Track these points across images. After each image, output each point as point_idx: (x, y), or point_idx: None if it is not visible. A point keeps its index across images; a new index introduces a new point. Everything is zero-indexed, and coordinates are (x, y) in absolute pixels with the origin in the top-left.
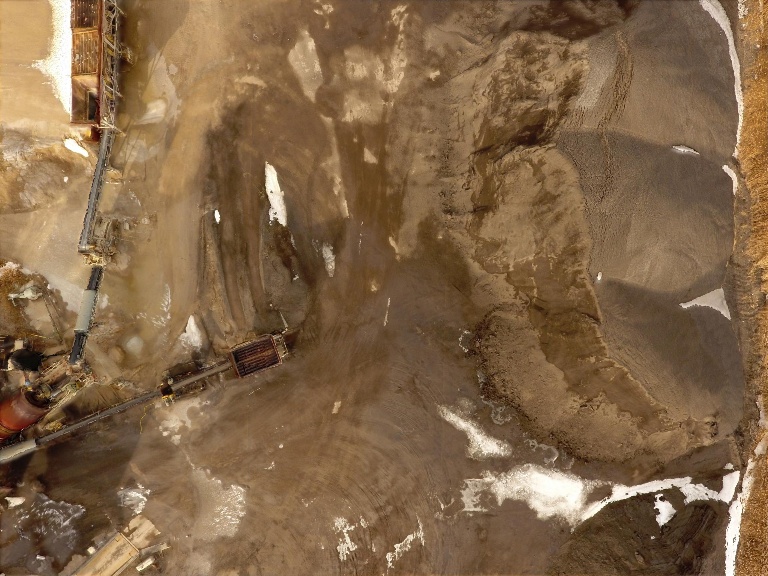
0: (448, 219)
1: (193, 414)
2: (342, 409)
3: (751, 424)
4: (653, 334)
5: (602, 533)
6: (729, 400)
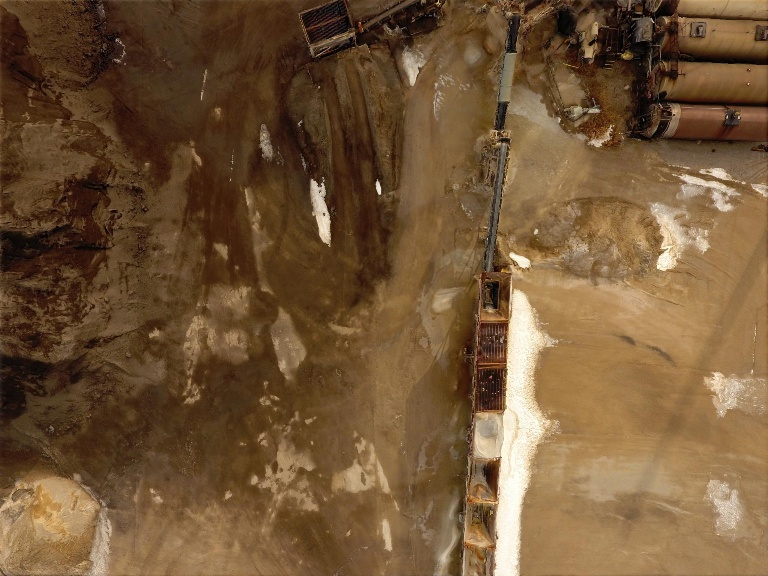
0: (138, 183)
1: None
2: None
3: None
4: None
5: None
6: None
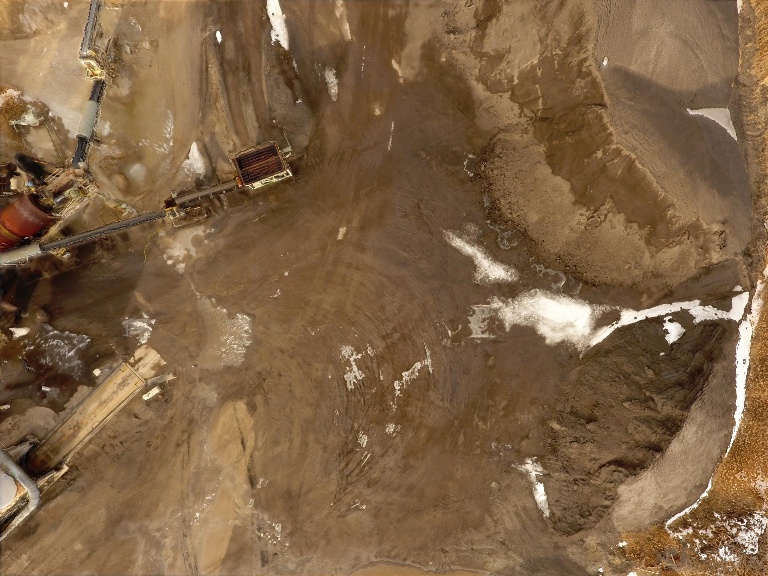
0: (451, 40)
1: (197, 242)
2: (347, 235)
3: (759, 244)
4: (660, 123)
5: (611, 355)
6: (737, 213)
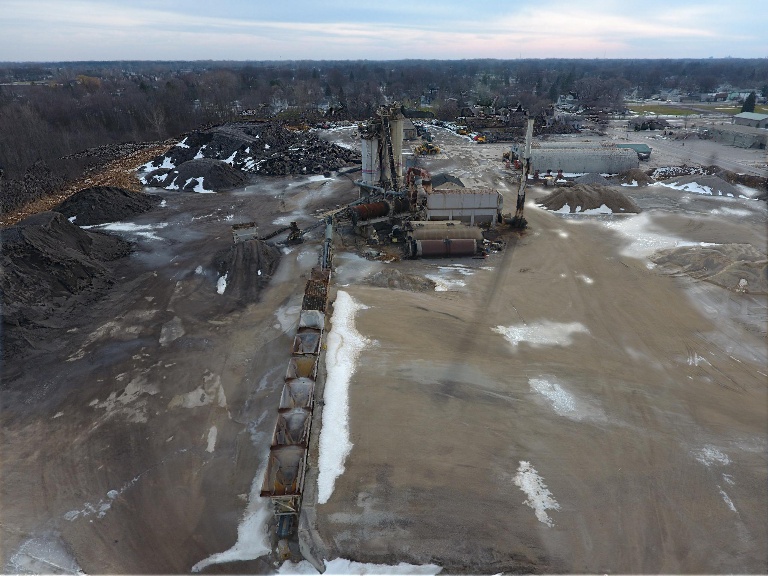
0: None
1: None
2: None
3: None
4: None
5: (106, 217)
6: None
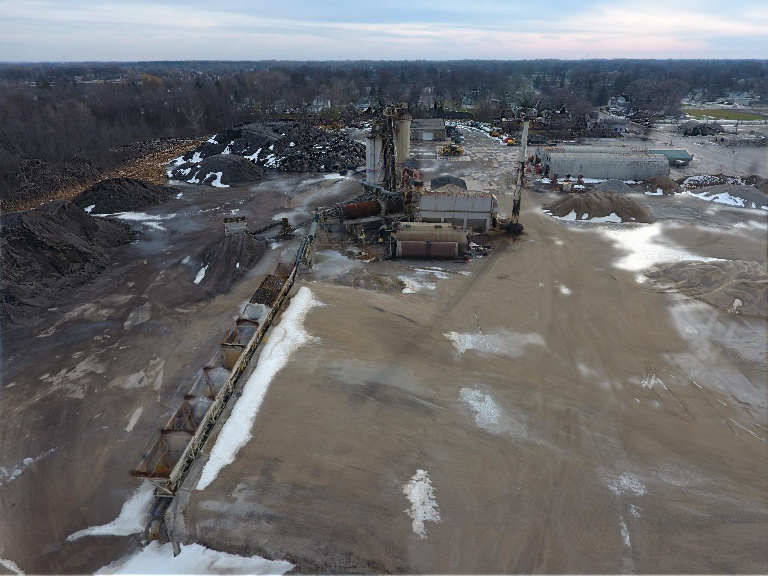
0: None
1: None
2: (213, 230)
3: None
4: None
5: (122, 207)
6: None
